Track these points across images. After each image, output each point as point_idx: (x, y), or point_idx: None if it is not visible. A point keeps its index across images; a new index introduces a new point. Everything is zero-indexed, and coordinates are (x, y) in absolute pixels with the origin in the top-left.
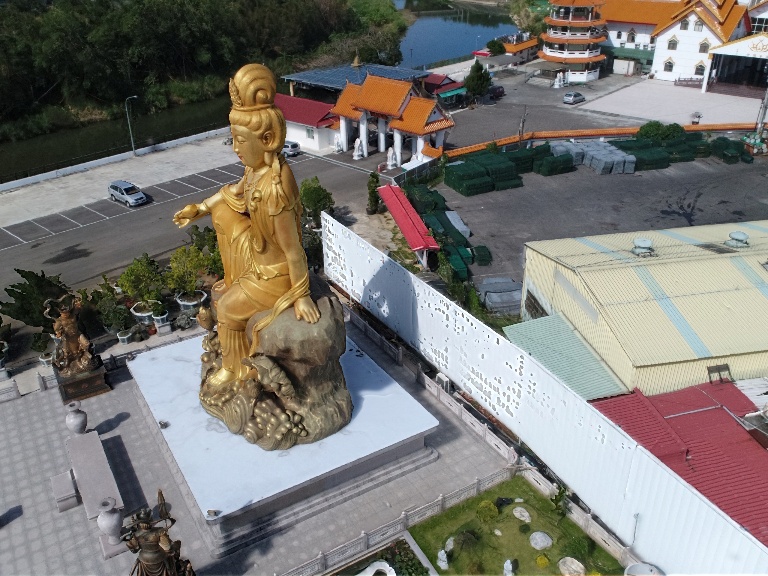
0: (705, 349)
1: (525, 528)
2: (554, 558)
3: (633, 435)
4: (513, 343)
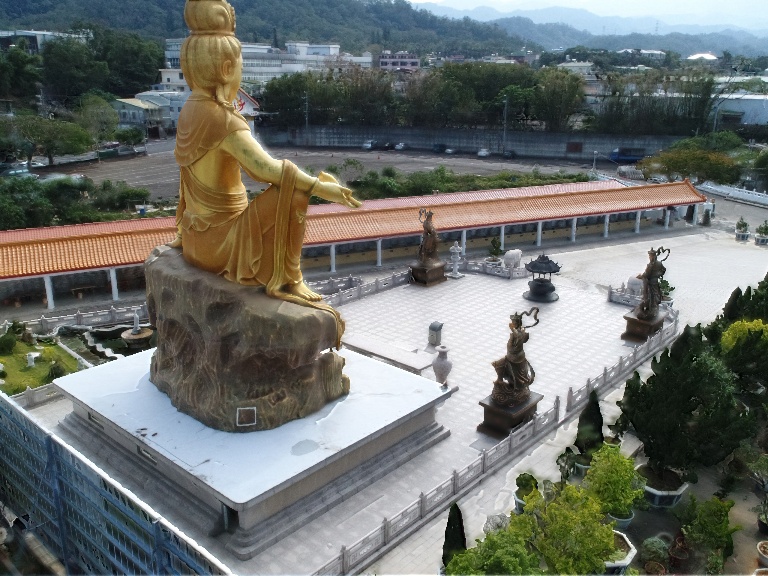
0: None
1: (3, 371)
2: None
3: None
4: None
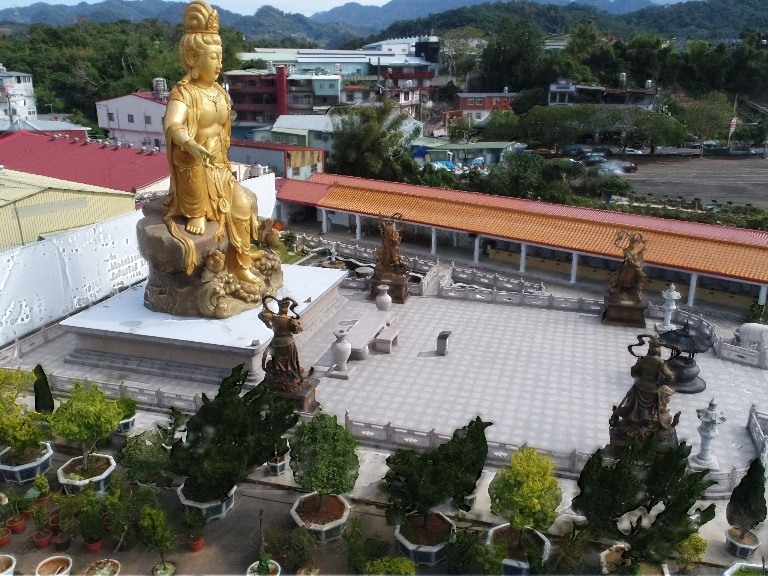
0: None
1: None
2: None
3: None
4: None
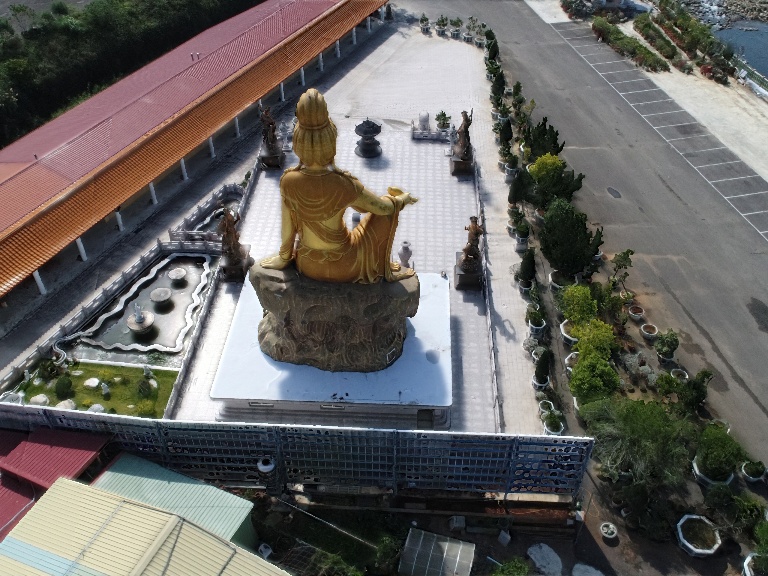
0: (3, 550)
1: (111, 409)
2: (82, 408)
3: (45, 449)
4: (224, 491)
